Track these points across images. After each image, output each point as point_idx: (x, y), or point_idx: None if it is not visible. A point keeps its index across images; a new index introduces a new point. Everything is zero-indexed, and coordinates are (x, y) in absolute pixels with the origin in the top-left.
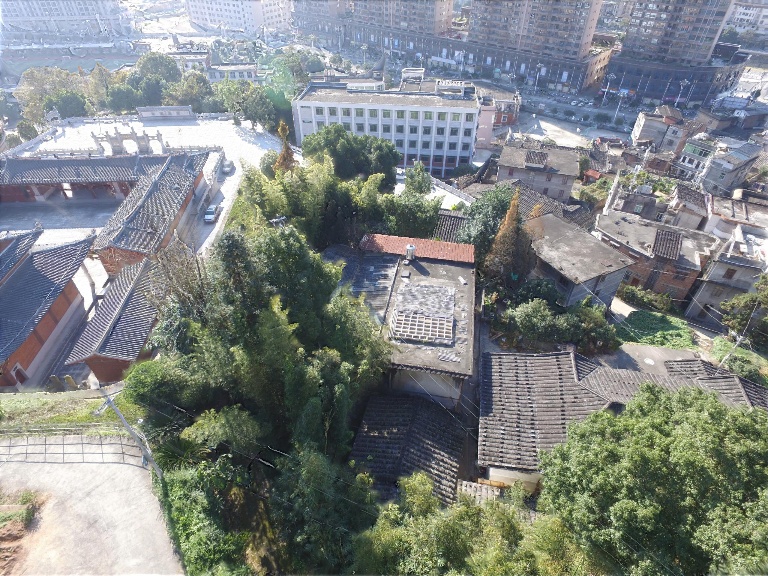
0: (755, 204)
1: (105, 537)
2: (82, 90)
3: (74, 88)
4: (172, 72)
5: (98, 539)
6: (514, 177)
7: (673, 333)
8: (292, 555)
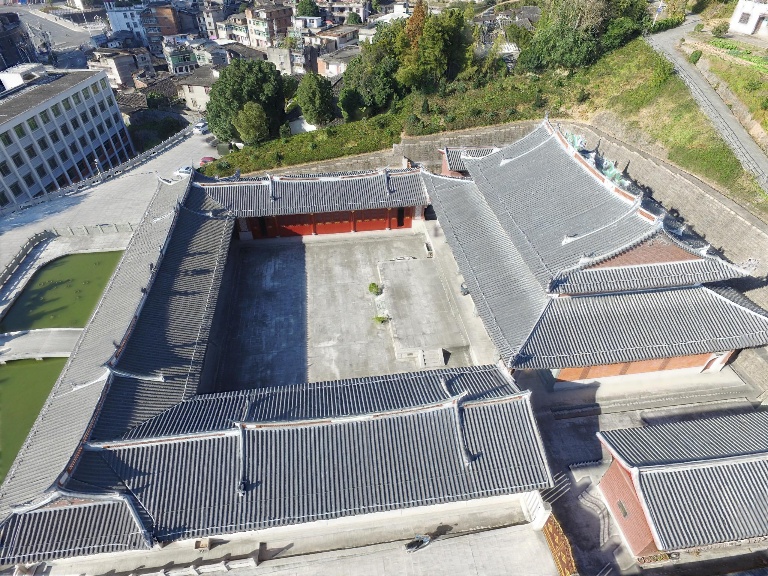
0: (328, 29)
1: None
2: None
3: None
4: None
5: None
6: None
7: None
8: None
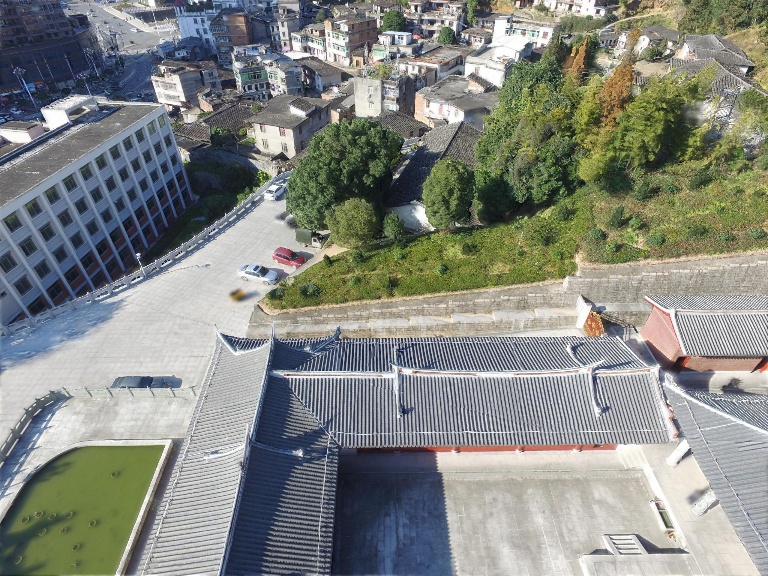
0: (426, 53)
1: None
2: None
3: None
4: None
5: None
6: (303, 133)
7: None
8: None
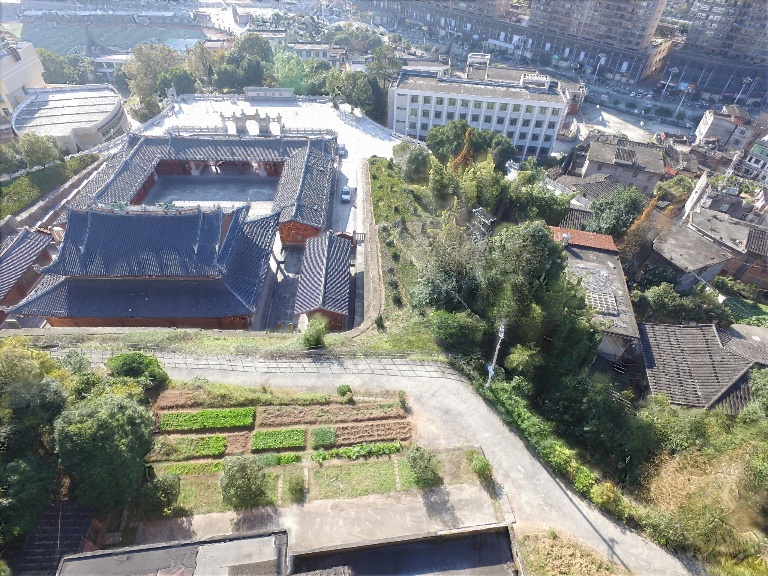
0: None
1: (460, 420)
2: (181, 66)
3: (176, 64)
4: (266, 53)
5: (456, 421)
6: (602, 171)
7: (766, 318)
8: (565, 443)
